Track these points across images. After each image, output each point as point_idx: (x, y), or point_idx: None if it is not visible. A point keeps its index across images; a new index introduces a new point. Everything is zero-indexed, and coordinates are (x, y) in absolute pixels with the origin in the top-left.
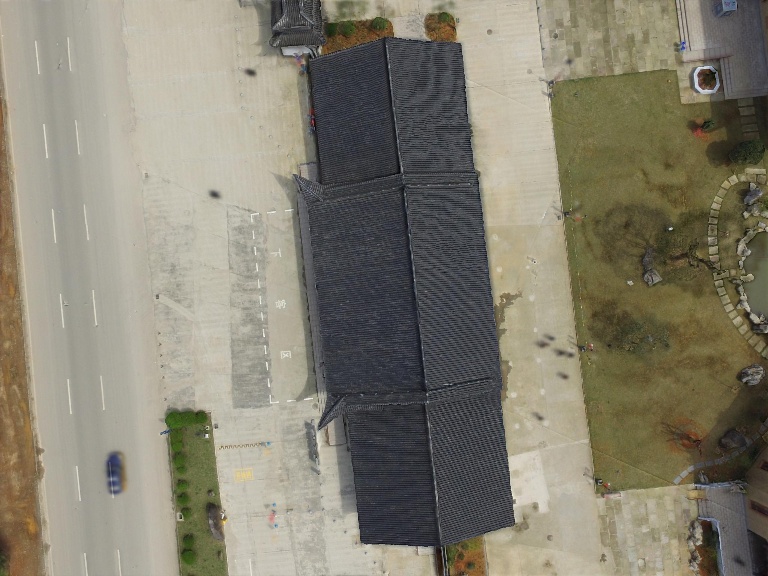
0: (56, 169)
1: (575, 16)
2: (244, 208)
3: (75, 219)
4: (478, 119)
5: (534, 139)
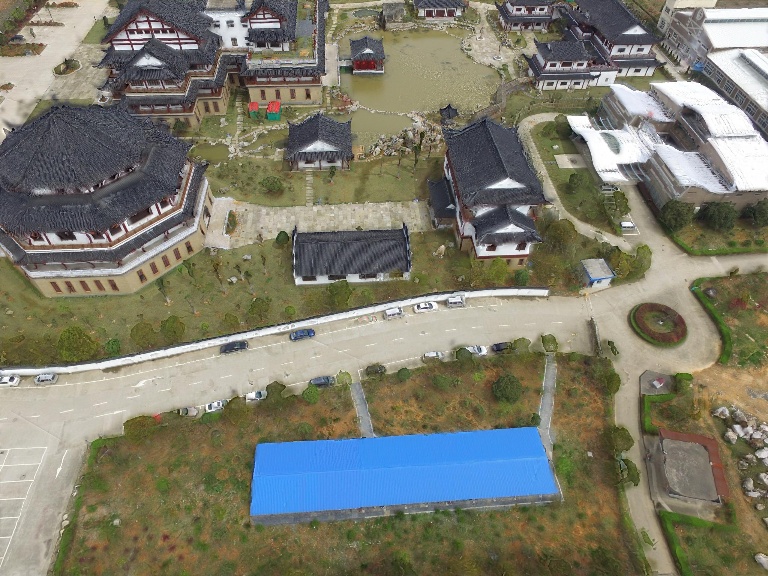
0: None
1: None
2: None
3: None
4: (4, 107)
5: None
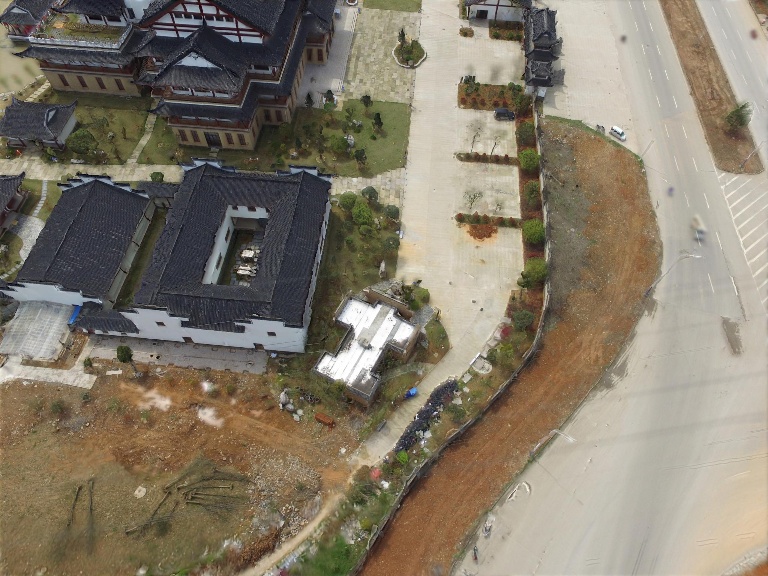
0: (645, 19)
1: (403, 28)
2: (561, 0)
3: (635, 6)
4: (454, 8)
5: (431, 0)
